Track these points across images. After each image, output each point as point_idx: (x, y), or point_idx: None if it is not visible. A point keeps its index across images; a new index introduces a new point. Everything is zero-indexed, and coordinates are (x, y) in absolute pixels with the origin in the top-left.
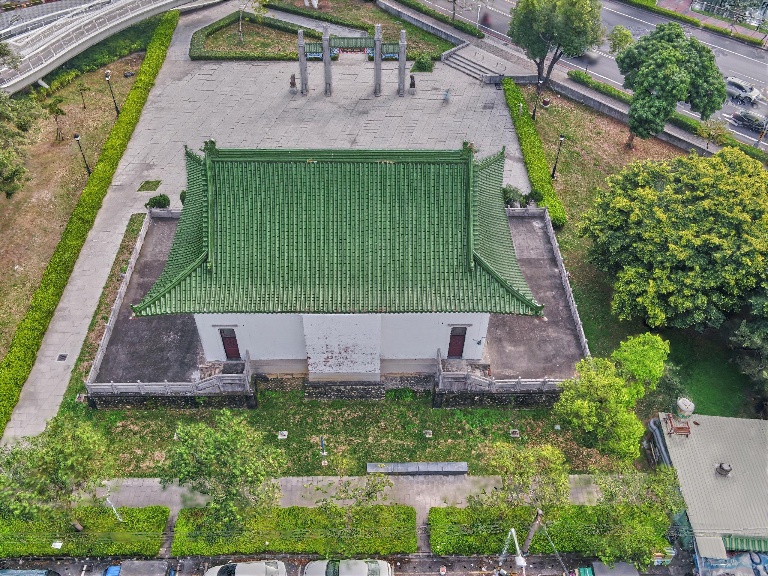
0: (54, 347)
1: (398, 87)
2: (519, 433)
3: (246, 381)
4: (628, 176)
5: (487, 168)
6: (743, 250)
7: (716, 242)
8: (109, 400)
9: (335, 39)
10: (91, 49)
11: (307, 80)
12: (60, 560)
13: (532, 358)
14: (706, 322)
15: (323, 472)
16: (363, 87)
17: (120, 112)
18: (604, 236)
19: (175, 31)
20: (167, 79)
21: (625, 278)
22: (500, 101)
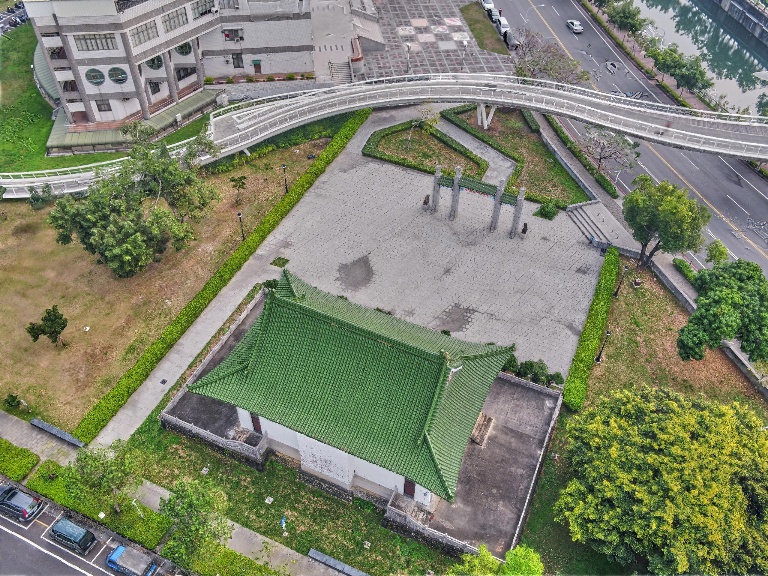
0: (162, 372)
1: (511, 229)
2: (433, 575)
3: (257, 453)
4: (618, 401)
5: (491, 357)
6: (656, 513)
7: (638, 496)
8: (174, 428)
9: (465, 180)
10: (292, 129)
11: (438, 202)
12: (101, 525)
13: (472, 520)
14: (615, 556)
15: (281, 540)
16: (484, 219)
17: (288, 191)
18: (573, 445)
19: (362, 125)
20: (336, 168)
21: (567, 490)
22: (596, 268)
